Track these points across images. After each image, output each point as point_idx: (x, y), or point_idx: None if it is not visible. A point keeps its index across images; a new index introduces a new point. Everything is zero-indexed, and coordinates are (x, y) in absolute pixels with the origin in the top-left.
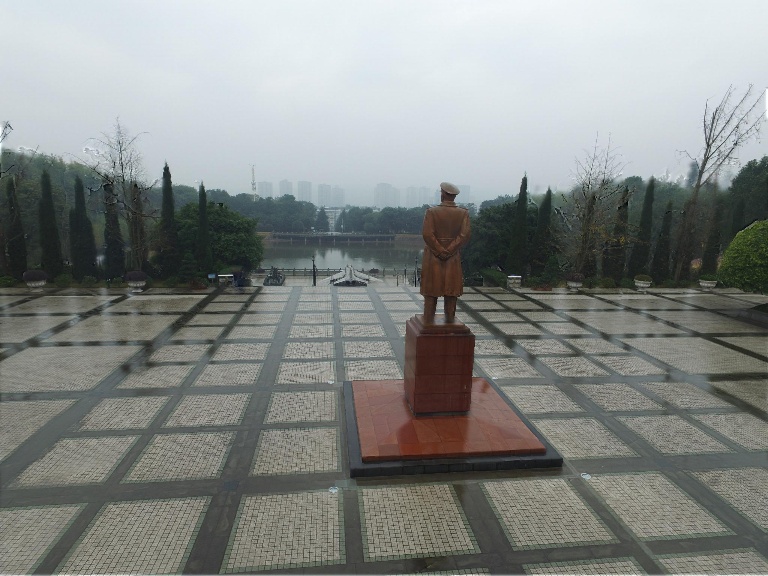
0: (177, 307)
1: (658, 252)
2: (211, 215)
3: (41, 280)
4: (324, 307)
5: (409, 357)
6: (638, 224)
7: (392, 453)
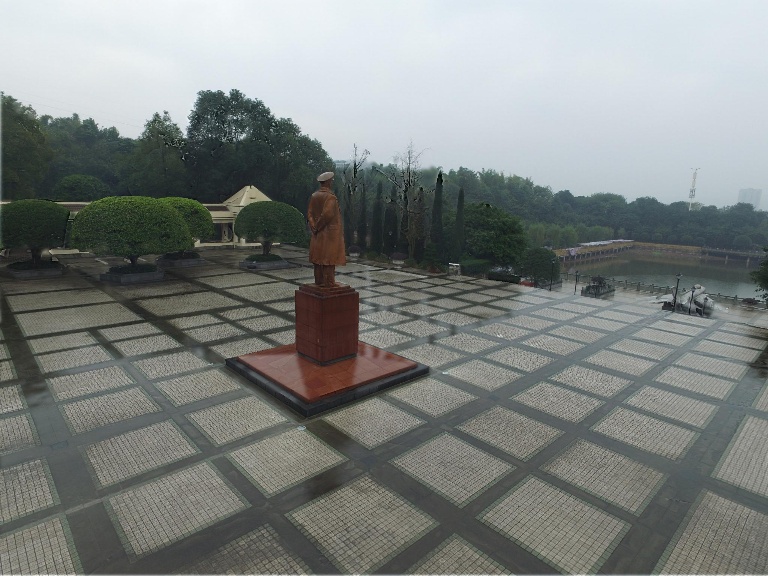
0: (390, 279)
1: None
2: (474, 214)
3: (355, 252)
4: (480, 299)
5: None
6: None
7: (248, 361)
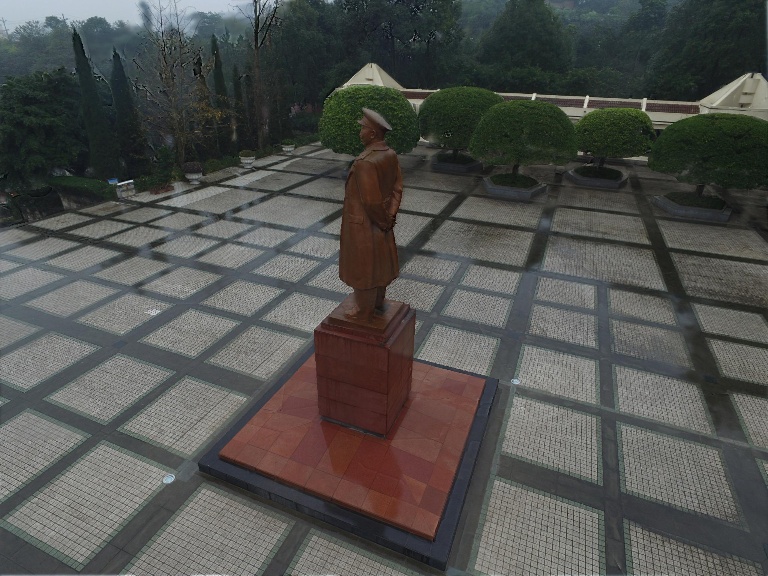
0: None
1: (239, 122)
2: None
3: None
4: None
5: (348, 376)
6: (214, 93)
7: (441, 500)
